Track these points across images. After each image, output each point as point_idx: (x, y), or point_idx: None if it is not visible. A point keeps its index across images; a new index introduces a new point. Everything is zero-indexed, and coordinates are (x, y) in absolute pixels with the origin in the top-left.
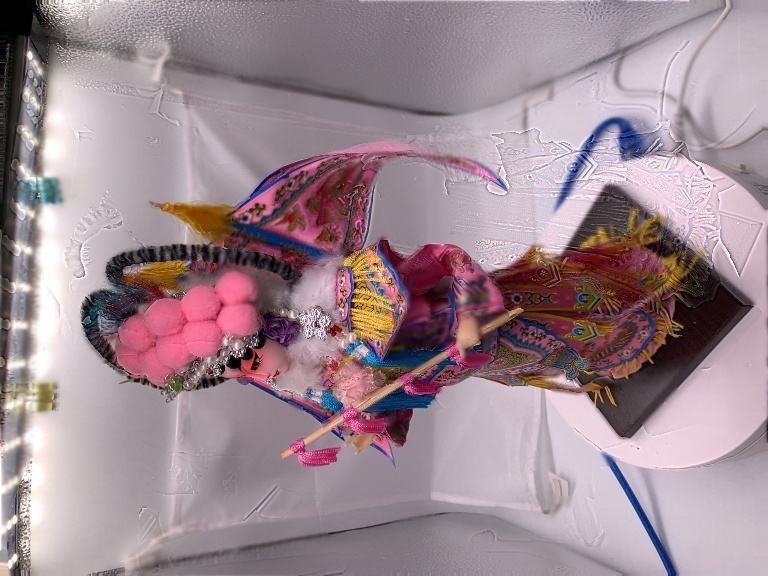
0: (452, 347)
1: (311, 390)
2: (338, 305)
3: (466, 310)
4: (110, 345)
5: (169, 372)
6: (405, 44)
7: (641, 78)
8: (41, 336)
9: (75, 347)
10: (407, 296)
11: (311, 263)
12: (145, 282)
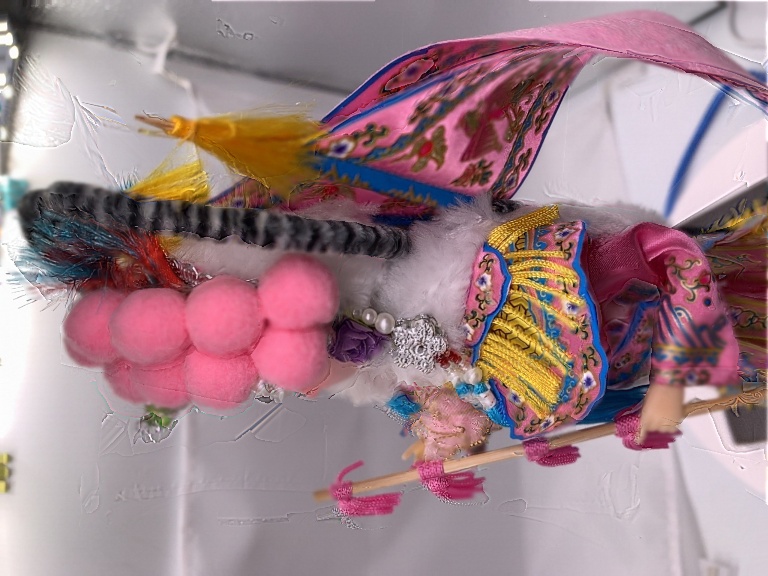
0: (632, 420)
1: None
2: (465, 318)
3: (675, 365)
4: None
5: (151, 412)
6: None
7: None
8: None
9: None
10: (610, 359)
11: (426, 216)
12: (120, 229)
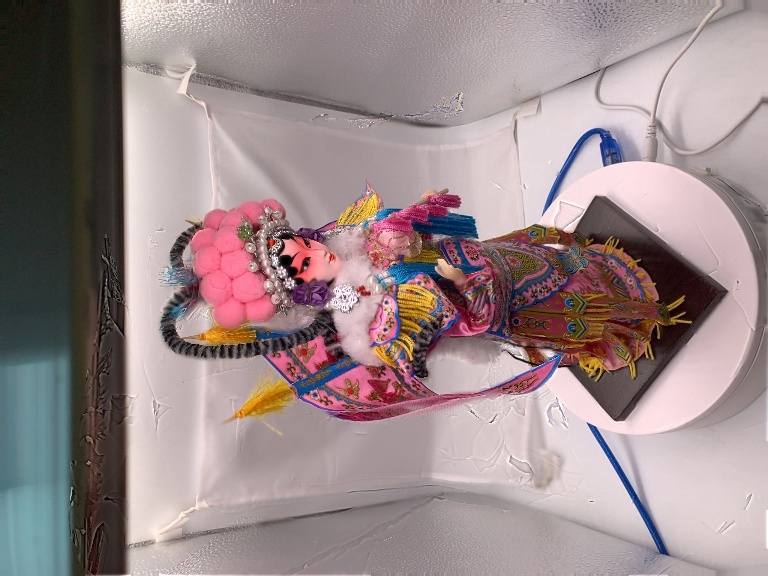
0: None
1: None
2: None
3: None
4: None
5: None
6: None
7: None
8: None
9: (167, 448)
10: None
11: None
12: None
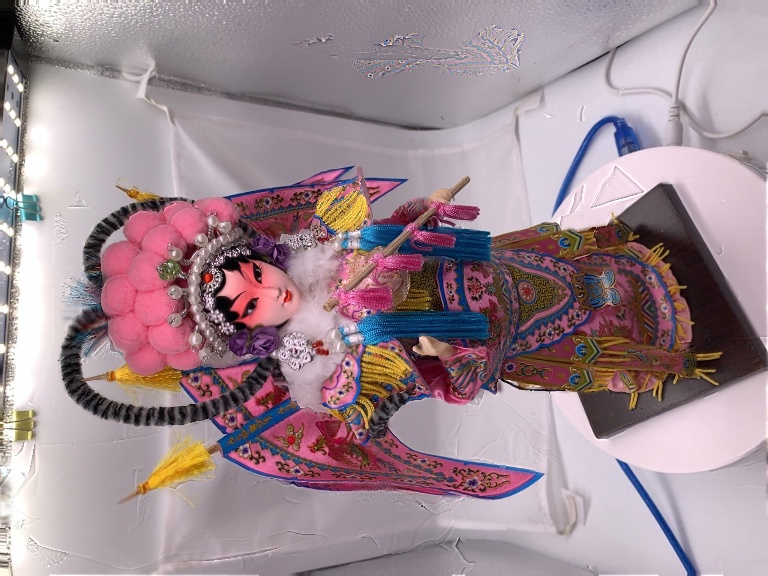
0: None
1: (343, 327)
2: None
3: None
4: (99, 395)
5: (161, 262)
6: None
7: None
8: None
9: (56, 510)
10: None
11: None
12: None
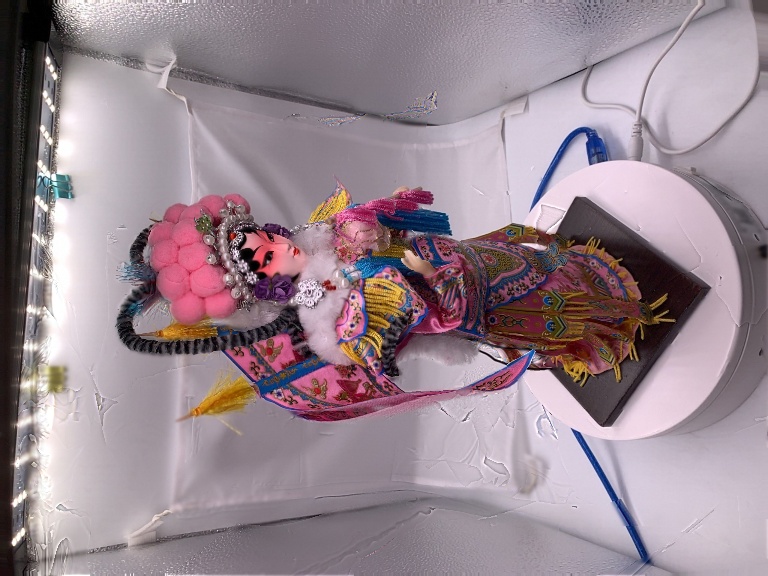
0: None
1: None
2: None
3: None
4: None
5: None
6: None
7: (521, 393)
8: None
9: (119, 449)
10: None
11: None
12: None
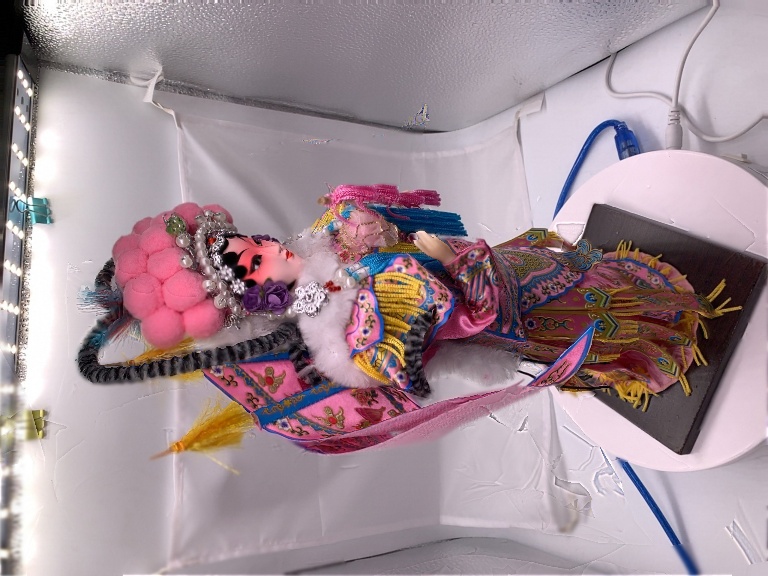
0: None
1: None
2: None
3: None
4: None
5: None
6: (399, 575)
7: (569, 453)
8: (23, 515)
9: (79, 508)
10: None
11: None
12: None
